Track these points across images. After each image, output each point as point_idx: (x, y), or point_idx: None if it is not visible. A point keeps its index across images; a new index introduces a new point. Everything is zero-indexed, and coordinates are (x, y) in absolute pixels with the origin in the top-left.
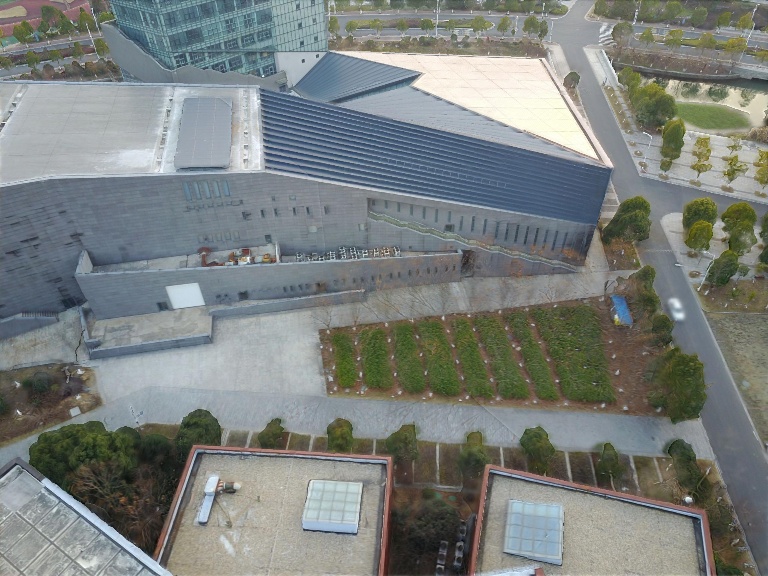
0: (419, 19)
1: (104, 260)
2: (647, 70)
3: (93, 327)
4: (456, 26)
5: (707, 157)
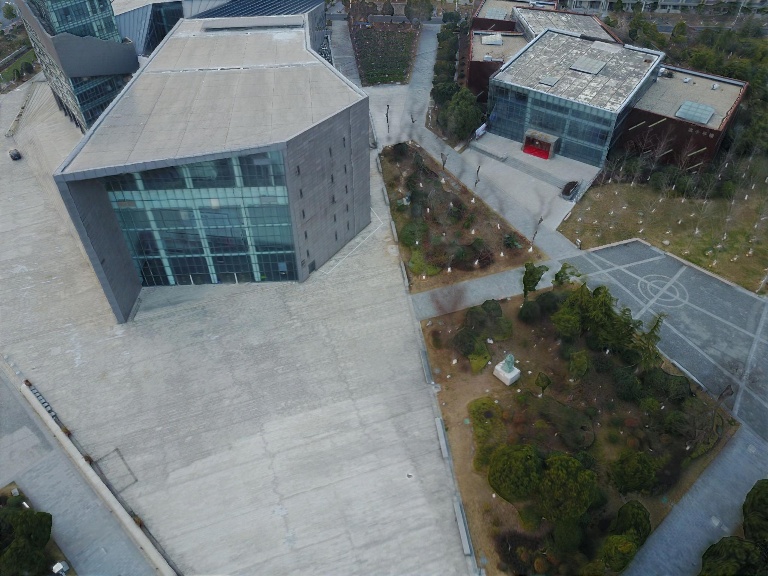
0: None
1: None
2: None
3: None
4: None
5: None
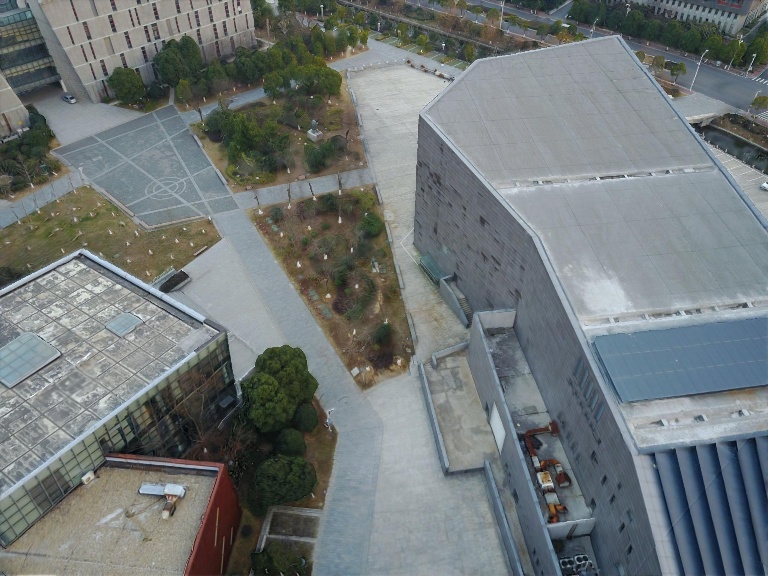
0: None
1: None
2: None
3: (458, 356)
4: None
5: None
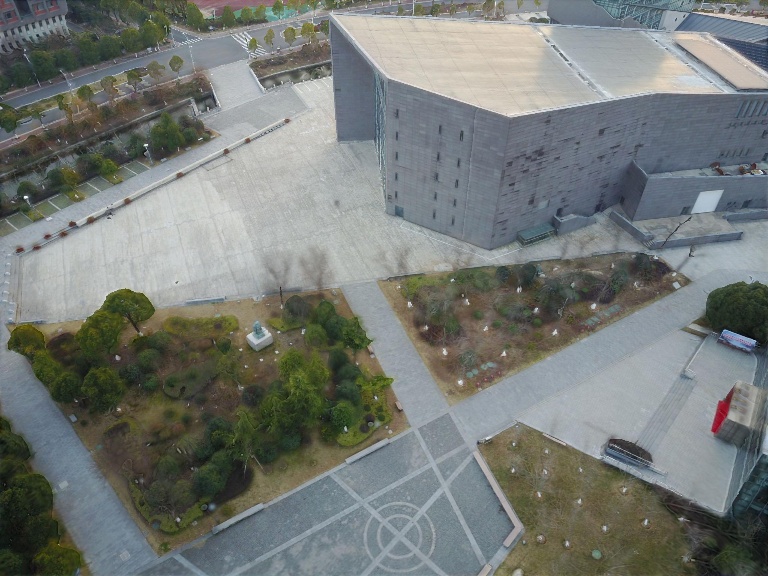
0: None
1: None
2: None
3: None
4: (711, 1)
5: None
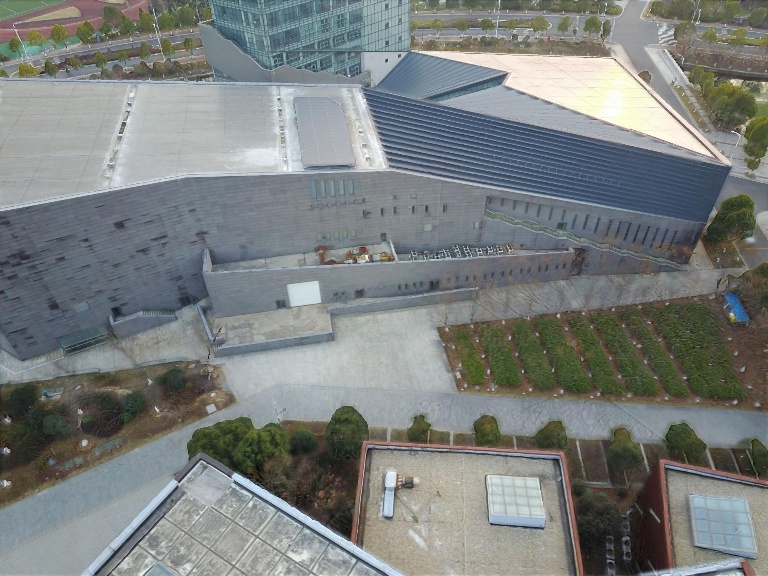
0: (476, 19)
1: (223, 258)
2: (711, 69)
3: (213, 325)
4: None
5: None
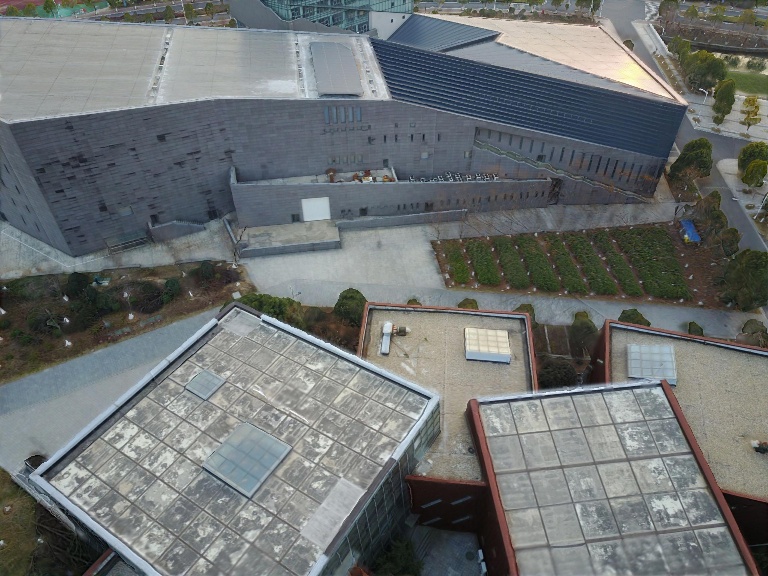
0: None
1: (247, 177)
2: (691, 43)
3: (237, 234)
4: None
5: (755, 113)
